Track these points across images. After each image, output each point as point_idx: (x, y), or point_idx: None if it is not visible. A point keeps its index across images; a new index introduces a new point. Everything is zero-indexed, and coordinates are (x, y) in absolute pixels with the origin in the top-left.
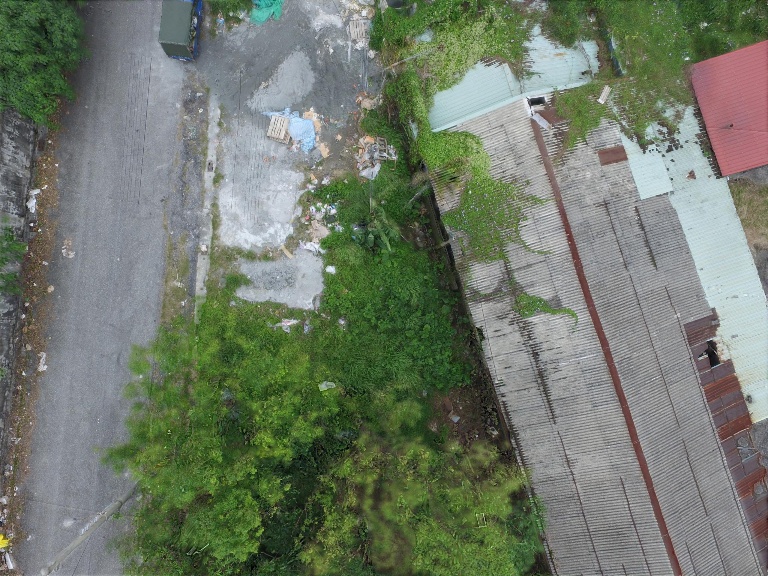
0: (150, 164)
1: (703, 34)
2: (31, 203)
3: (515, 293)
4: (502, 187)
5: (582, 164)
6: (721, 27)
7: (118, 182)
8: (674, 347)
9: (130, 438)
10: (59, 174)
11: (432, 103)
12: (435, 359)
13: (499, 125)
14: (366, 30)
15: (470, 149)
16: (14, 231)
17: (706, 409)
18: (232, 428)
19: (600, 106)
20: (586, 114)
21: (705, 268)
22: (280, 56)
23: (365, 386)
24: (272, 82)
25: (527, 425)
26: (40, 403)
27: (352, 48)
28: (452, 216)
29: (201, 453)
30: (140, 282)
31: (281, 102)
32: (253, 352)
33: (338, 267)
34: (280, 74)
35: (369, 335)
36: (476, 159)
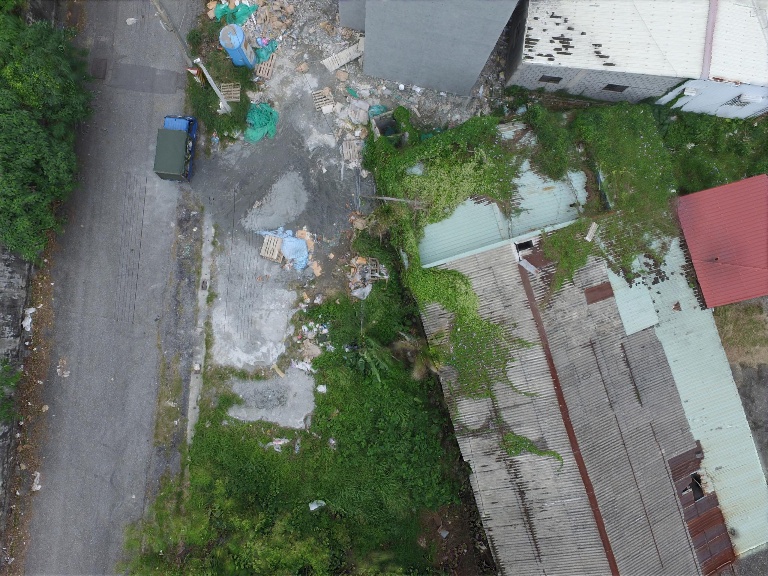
0: (144, 283)
1: (690, 156)
2: (27, 322)
3: (502, 431)
4: (490, 328)
5: (569, 305)
6: (708, 148)
7: (113, 302)
8: (658, 484)
9: (122, 559)
10: (54, 293)
11: (422, 235)
12: (424, 480)
13: (487, 267)
14: (359, 150)
15: (459, 290)
16: (9, 353)
17: (689, 545)
18: (223, 556)
19: (587, 244)
20: (573, 255)
21: (690, 400)
22: (274, 175)
23: (355, 509)
24: (266, 201)
25: (513, 560)
26: (34, 523)
27: (345, 168)
28: (441, 352)
29: (192, 574)
30: (134, 402)
31: (274, 222)
32: (245, 474)
33: (329, 387)
34: (274, 194)
35: (359, 458)
36: (465, 300)
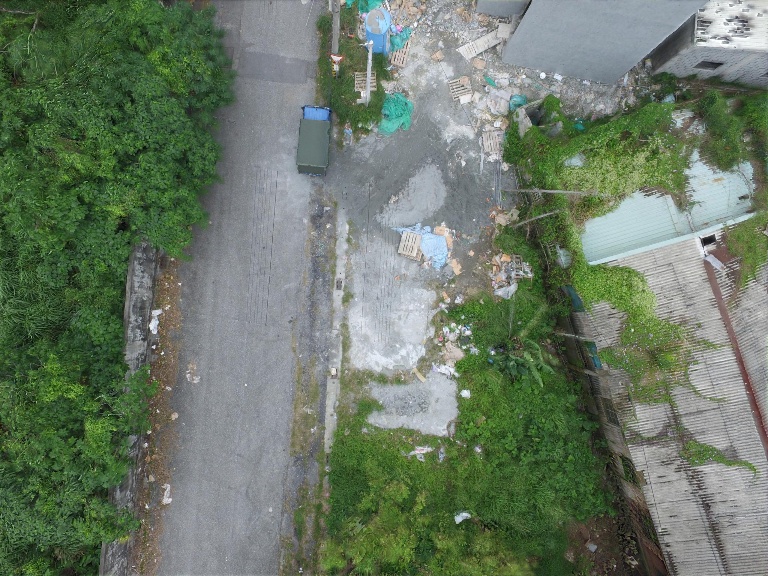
0: (277, 283)
1: None
2: (153, 324)
3: (683, 439)
4: (670, 328)
5: (753, 303)
6: None
7: (244, 302)
8: None
9: None
10: (182, 294)
11: (584, 230)
12: (578, 491)
13: (667, 263)
14: (500, 142)
15: (636, 288)
16: (139, 358)
17: None
18: (375, 574)
19: (766, 238)
20: (756, 250)
21: None
22: (410, 169)
23: (508, 522)
24: (403, 196)
25: None
26: (165, 539)
27: (485, 160)
28: (612, 354)
29: None
30: (268, 409)
31: (413, 218)
32: (389, 486)
33: (474, 392)
34: (412, 188)
35: (511, 467)
36: (642, 298)
